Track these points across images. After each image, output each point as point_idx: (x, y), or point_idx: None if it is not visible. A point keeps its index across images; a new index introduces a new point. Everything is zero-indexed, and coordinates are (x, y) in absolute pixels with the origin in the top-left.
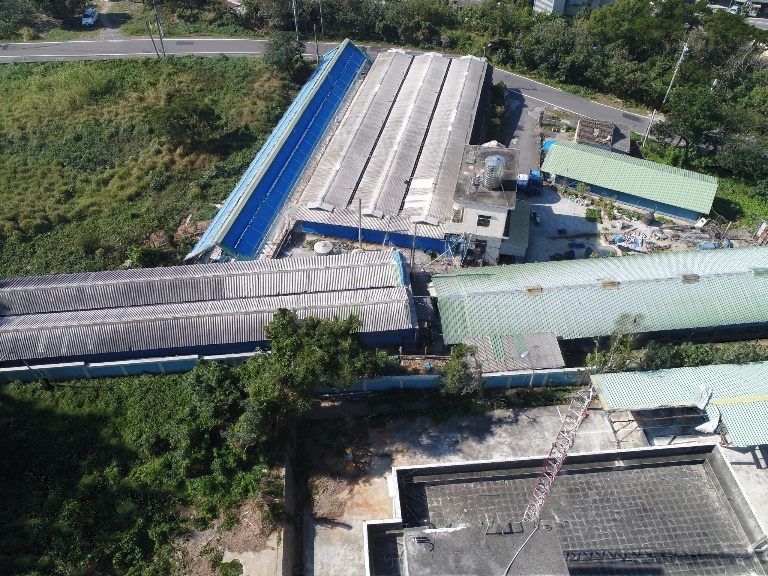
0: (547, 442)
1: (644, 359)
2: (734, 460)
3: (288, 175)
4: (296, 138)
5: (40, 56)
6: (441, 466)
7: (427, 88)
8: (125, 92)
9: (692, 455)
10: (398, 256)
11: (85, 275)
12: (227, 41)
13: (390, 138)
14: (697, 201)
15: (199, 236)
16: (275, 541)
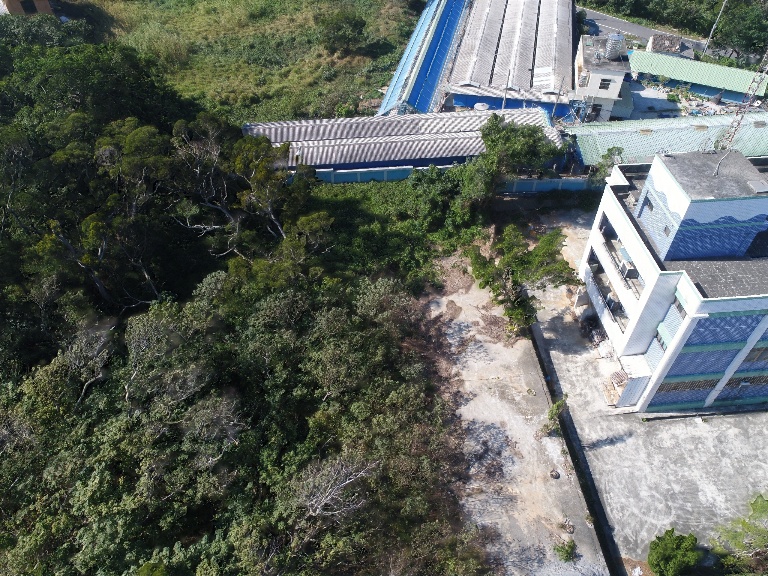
0: None
1: None
2: None
3: (437, 65)
4: (436, 41)
5: None
6: (644, 164)
7: (528, 10)
8: (277, 15)
9: None
10: (542, 109)
11: (312, 121)
12: None
13: (509, 42)
14: (754, 87)
15: (373, 108)
16: None
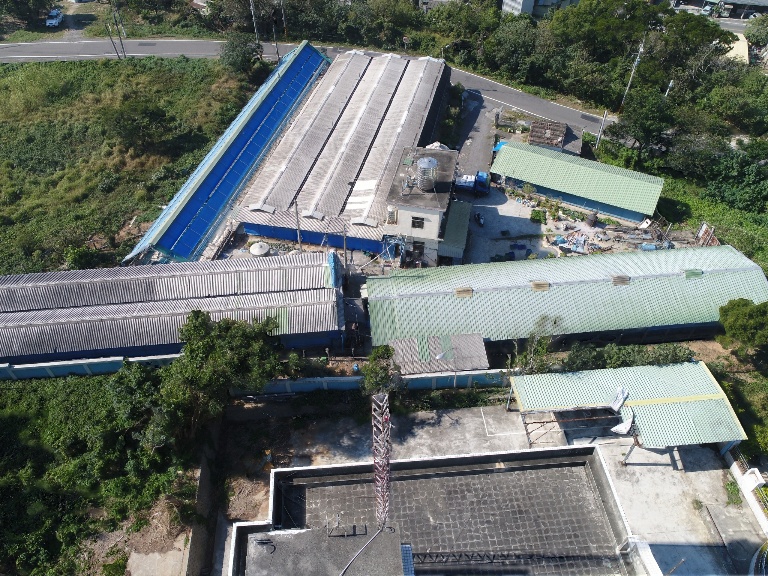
0: (467, 443)
1: (567, 360)
2: (651, 461)
3: (233, 177)
4: (244, 140)
5: (1, 57)
6: (319, 468)
7: (381, 89)
8: (82, 93)
9: (573, 457)
10: (331, 258)
11: (18, 277)
12: (190, 42)
13: (339, 139)
14: (642, 202)
15: None
16: (182, 542)
